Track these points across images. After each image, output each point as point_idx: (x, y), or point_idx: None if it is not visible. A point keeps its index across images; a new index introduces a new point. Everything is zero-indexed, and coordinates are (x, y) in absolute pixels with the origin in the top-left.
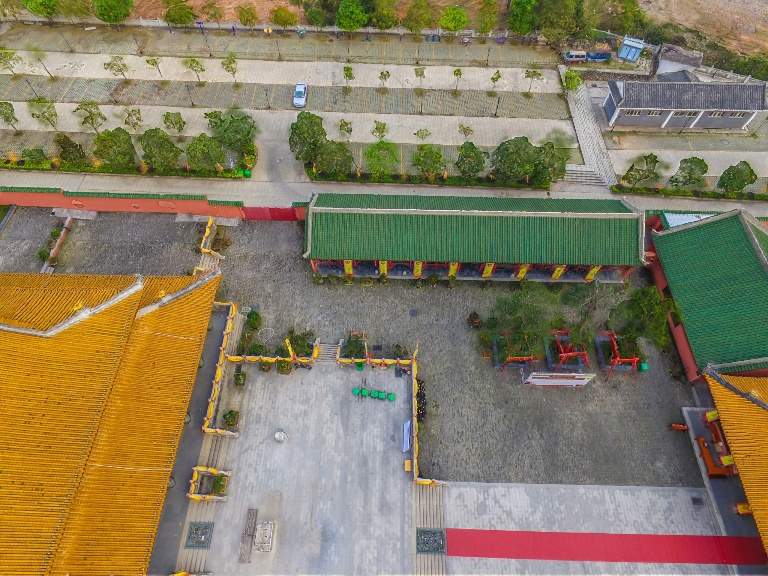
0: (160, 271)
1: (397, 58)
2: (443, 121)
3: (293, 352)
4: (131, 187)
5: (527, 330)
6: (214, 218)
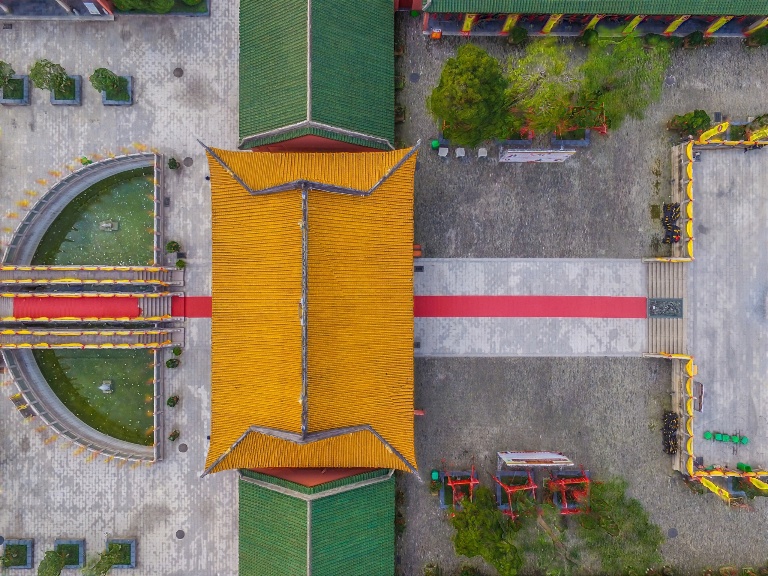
0: None
1: None
2: None
3: None
4: None
5: None
6: None
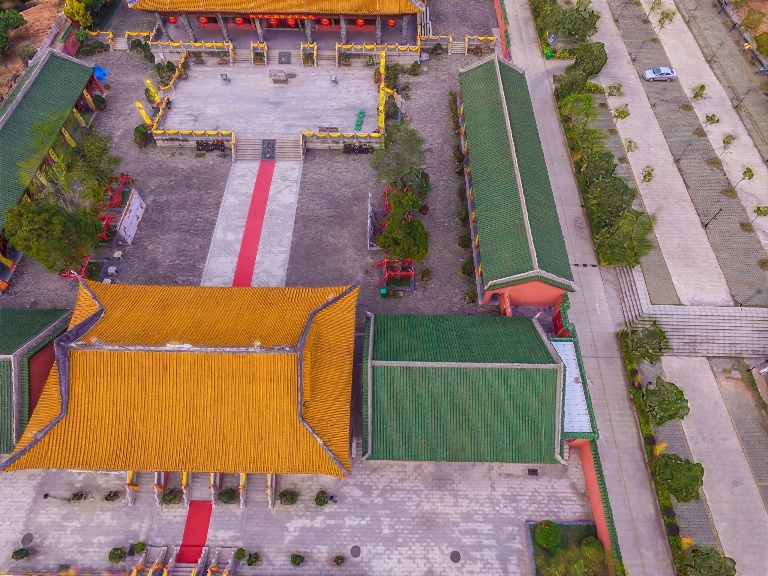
0: (449, 27)
1: (767, 145)
2: (673, 179)
3: (385, 73)
4: (520, 8)
5: (419, 219)
6: (500, 45)
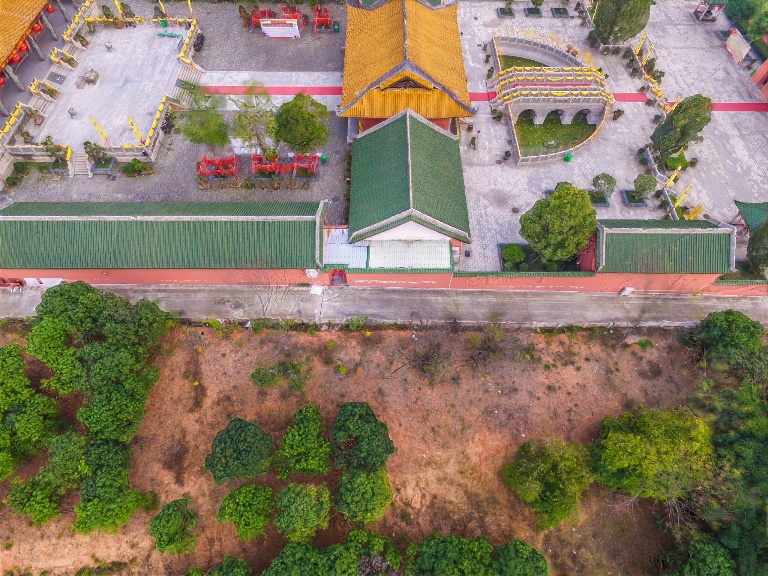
0: None
1: None
2: None
3: (122, 12)
4: None
5: None
6: None
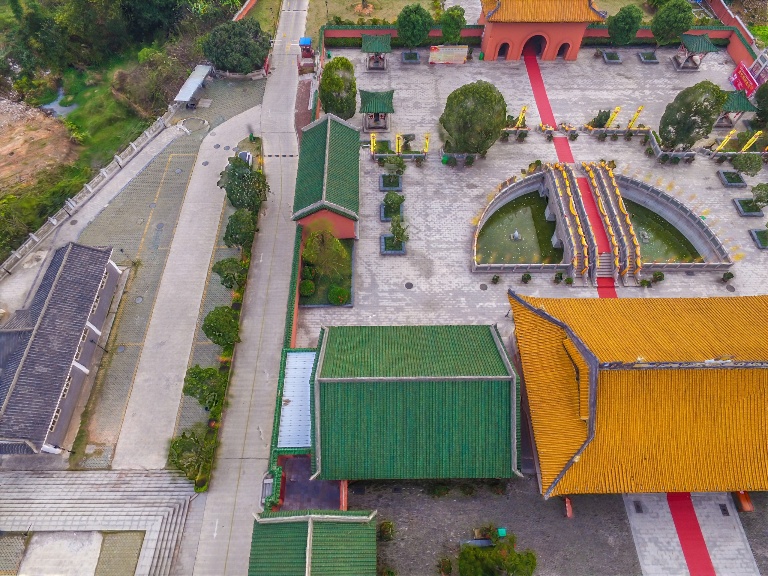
0: None
1: None
2: None
3: None
4: None
5: None
6: None
